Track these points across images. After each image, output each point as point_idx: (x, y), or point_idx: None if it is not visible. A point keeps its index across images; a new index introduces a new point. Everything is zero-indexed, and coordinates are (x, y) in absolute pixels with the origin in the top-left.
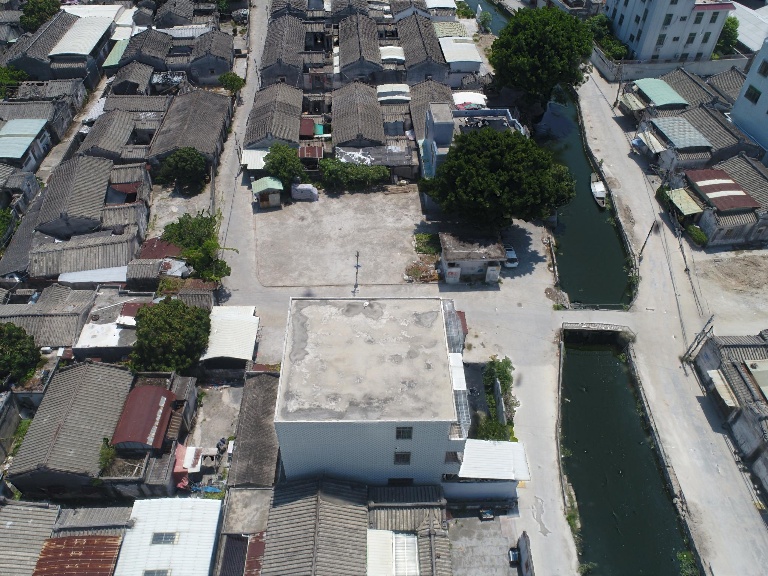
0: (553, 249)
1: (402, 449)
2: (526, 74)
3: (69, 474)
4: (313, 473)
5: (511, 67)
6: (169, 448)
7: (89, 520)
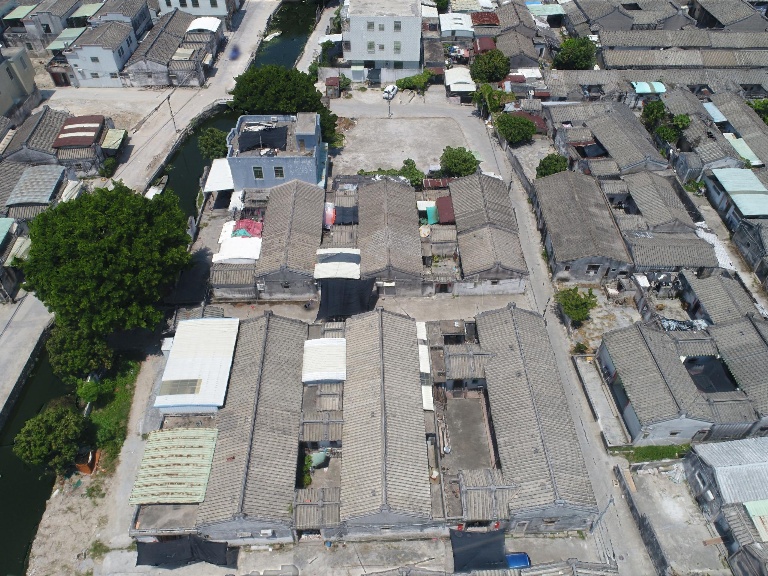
0: None
1: None
2: None
3: None
4: None
5: None
6: None
7: (489, 30)
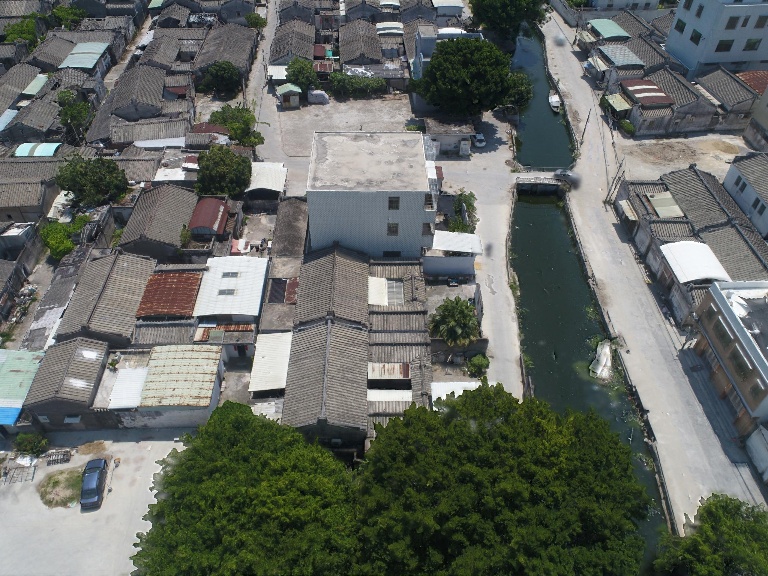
0: (514, 136)
1: (393, 220)
2: (498, 10)
3: (161, 244)
4: (331, 245)
5: (486, 5)
6: (227, 239)
7: None
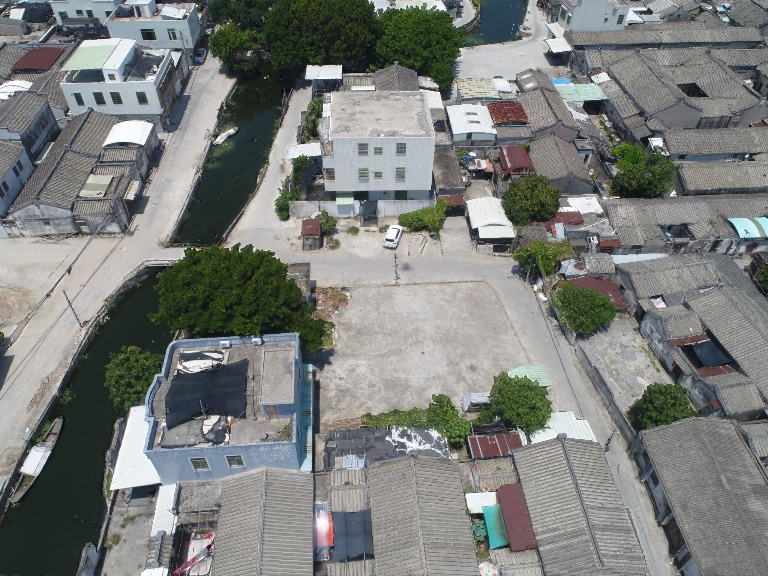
0: None
1: None
2: None
3: None
4: None
5: None
6: None
7: (516, 131)
